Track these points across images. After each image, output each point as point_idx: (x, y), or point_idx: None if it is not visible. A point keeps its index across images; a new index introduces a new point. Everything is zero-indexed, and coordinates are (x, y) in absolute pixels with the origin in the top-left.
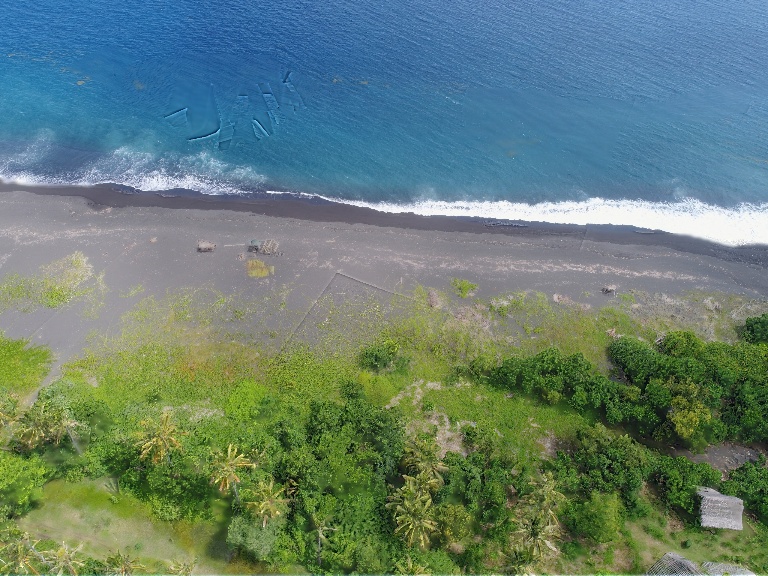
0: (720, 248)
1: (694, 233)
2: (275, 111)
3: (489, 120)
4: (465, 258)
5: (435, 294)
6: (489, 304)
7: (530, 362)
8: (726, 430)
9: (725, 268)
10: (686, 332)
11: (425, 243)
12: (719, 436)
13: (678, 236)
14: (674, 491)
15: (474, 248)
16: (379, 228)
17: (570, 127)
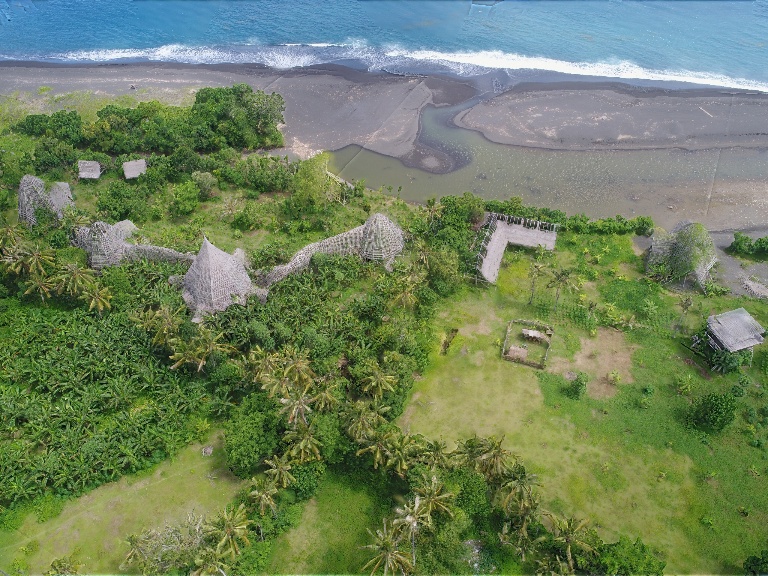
0: (244, 69)
1: (237, 63)
2: (6, 10)
3: (142, 5)
4: (63, 78)
5: (23, 93)
6: (52, 97)
7: (41, 116)
8: (136, 143)
9: (233, 78)
10: (153, 101)
11: (46, 73)
12: (131, 146)
13: (224, 64)
14: (74, 164)
15: (75, 74)
16: (25, 68)
17: (189, 4)
